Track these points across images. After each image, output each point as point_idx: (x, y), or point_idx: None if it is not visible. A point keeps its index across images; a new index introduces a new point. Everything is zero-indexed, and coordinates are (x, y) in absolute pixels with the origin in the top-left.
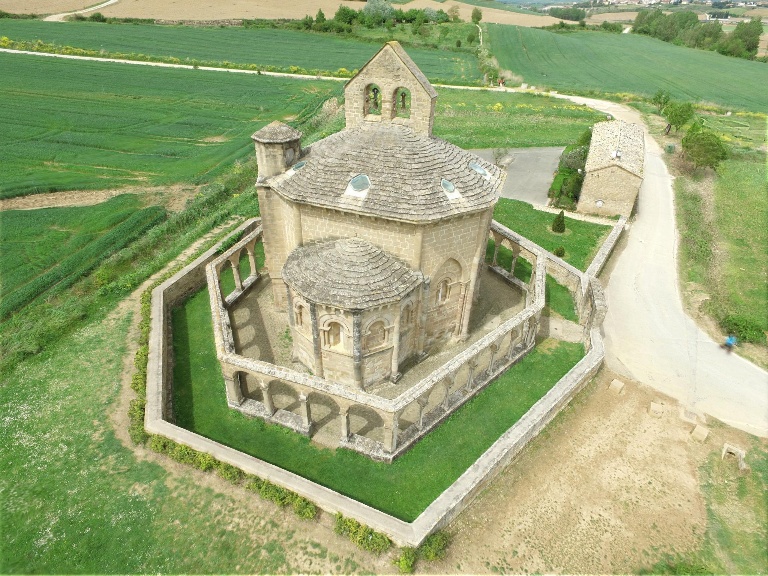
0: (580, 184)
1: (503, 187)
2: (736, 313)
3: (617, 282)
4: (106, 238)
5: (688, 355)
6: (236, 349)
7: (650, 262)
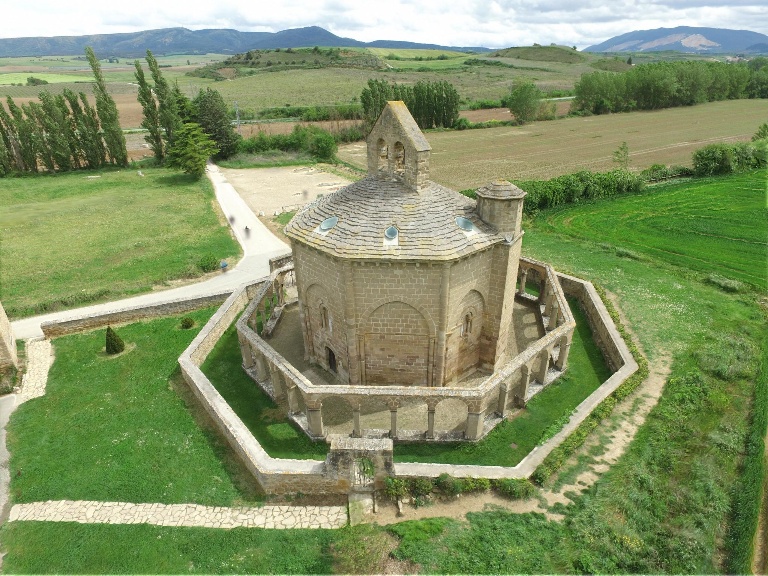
0: None
1: None
2: None
3: None
4: None
5: (262, 268)
6: None
7: None
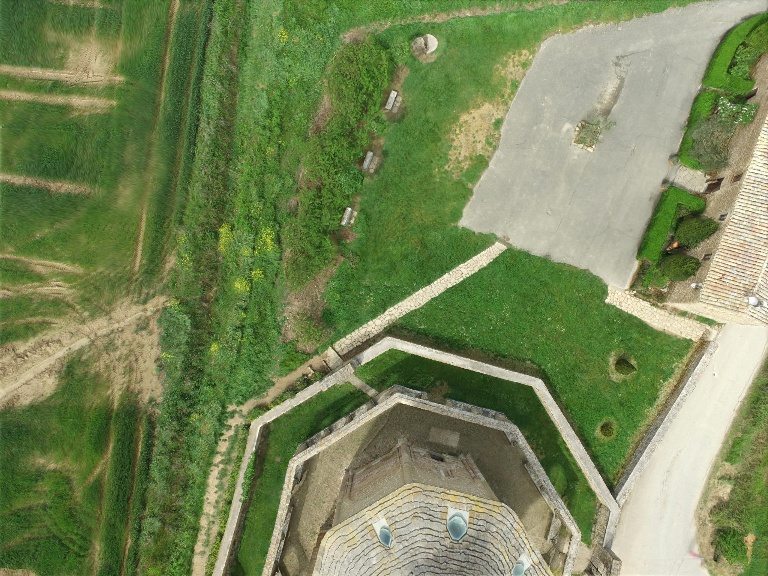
0: (687, 277)
1: (579, 225)
2: (740, 525)
3: (651, 471)
4: (116, 496)
5: None
6: None
7: (703, 424)
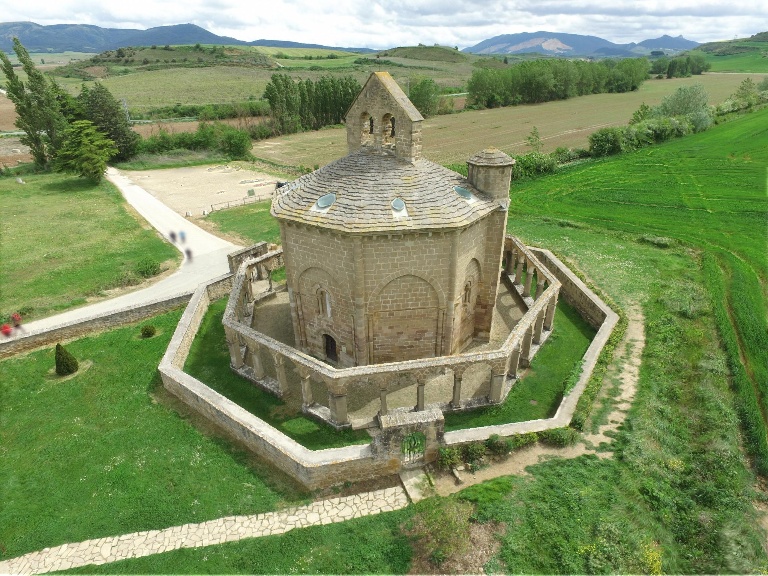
0: None
1: None
2: (128, 274)
3: None
4: None
5: None
6: (521, 303)
7: None
